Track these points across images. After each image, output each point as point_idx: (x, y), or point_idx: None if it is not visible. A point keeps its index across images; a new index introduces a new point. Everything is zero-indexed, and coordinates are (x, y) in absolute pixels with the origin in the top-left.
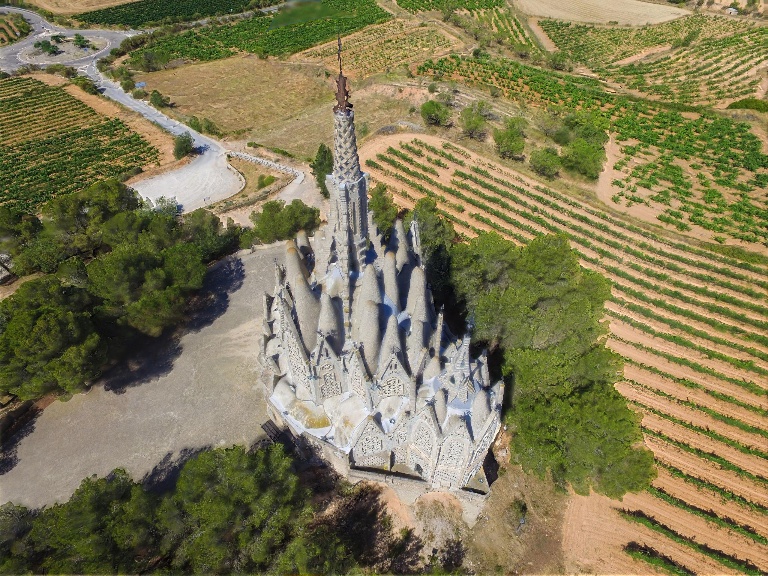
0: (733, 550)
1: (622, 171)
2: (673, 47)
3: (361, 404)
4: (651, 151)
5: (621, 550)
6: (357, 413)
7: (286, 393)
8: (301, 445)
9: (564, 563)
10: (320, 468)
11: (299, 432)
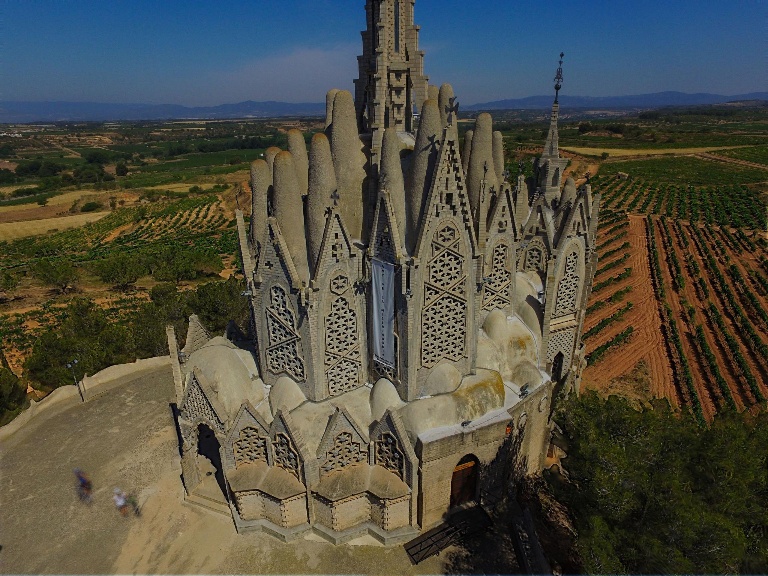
0: (584, 329)
1: (227, 269)
2: (135, 222)
3: (504, 315)
4: (225, 256)
5: (587, 368)
6: (512, 327)
7: (435, 403)
8: (505, 460)
9: (601, 398)
10: (521, 491)
11: (508, 416)
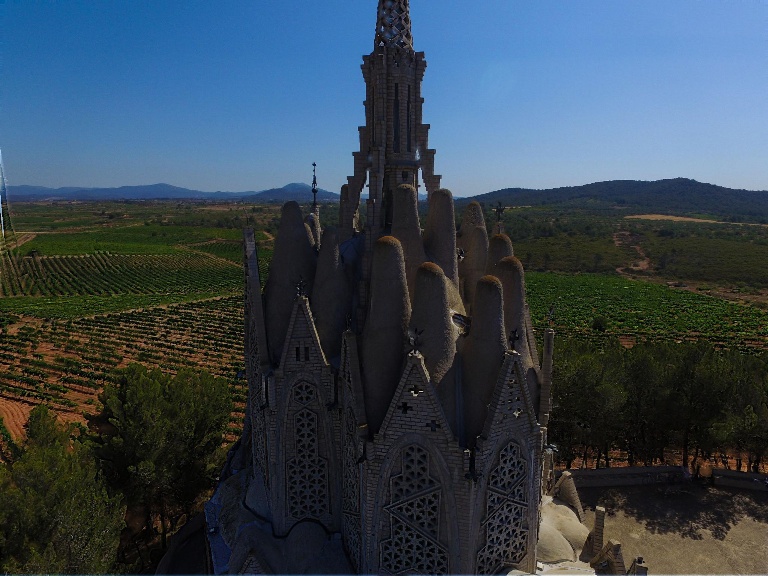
0: None
1: None
2: None
3: None
4: None
5: None
6: None
7: None
8: None
9: None
10: None
11: None
